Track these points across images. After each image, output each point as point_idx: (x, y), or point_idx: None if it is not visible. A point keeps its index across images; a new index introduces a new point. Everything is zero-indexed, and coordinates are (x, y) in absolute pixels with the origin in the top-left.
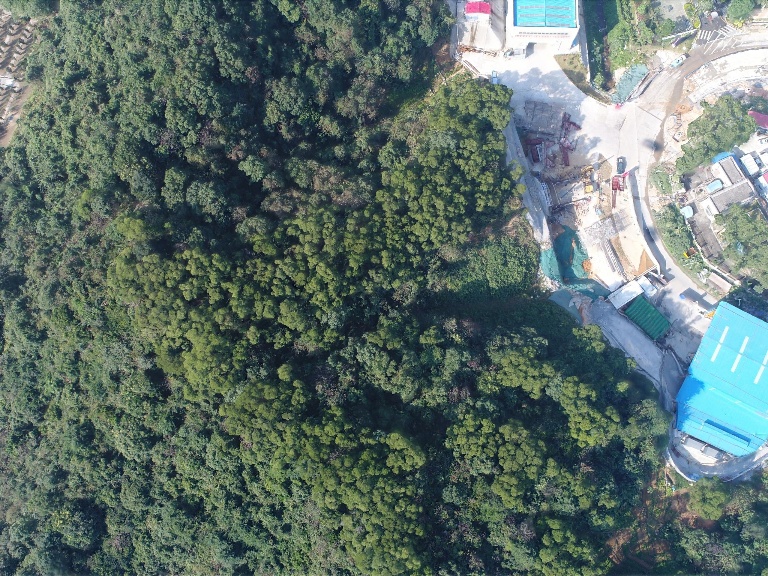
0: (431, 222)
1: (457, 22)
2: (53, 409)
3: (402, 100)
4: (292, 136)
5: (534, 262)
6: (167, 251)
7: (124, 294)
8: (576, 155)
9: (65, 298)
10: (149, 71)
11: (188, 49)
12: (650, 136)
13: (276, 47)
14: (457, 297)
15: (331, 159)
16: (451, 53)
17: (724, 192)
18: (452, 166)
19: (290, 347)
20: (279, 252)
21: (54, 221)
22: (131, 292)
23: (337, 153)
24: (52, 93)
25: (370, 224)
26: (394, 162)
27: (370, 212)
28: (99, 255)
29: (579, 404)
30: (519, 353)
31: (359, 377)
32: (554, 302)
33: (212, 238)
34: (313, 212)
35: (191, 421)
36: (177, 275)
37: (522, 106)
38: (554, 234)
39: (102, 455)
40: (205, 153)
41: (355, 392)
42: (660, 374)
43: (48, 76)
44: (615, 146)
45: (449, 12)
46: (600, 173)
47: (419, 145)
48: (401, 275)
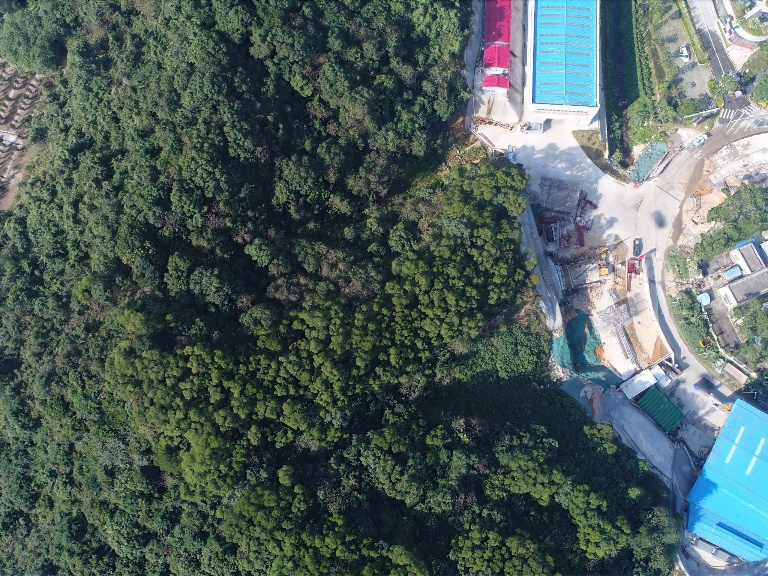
0: (442, 317)
1: (474, 95)
2: (45, 499)
3: (415, 174)
4: (301, 216)
5: (545, 350)
6: (168, 342)
7: (122, 391)
8: (592, 235)
9: (61, 388)
10: (156, 148)
11: (196, 127)
12: (668, 217)
13: (287, 123)
14: (465, 387)
15: (340, 239)
16: (466, 125)
17: (743, 281)
18: (465, 255)
19: (292, 444)
20: (284, 345)
21: (52, 303)
22: (129, 389)
23: (347, 235)
24: (55, 163)
25: (379, 318)
26: (405, 246)
27: (379, 306)
28: (97, 345)
29: (589, 515)
30: (528, 457)
31: (362, 479)
32: (565, 392)
33: (215, 330)
34: (320, 303)
35: (187, 521)
36: (177, 373)
37: (538, 182)
38: (567, 318)
39: (94, 551)
40: (211, 237)
41: (358, 496)
42: (672, 471)
43: (52, 141)
44: (632, 227)
45: (466, 85)
46: (616, 255)
47: (431, 230)
48: (409, 370)
